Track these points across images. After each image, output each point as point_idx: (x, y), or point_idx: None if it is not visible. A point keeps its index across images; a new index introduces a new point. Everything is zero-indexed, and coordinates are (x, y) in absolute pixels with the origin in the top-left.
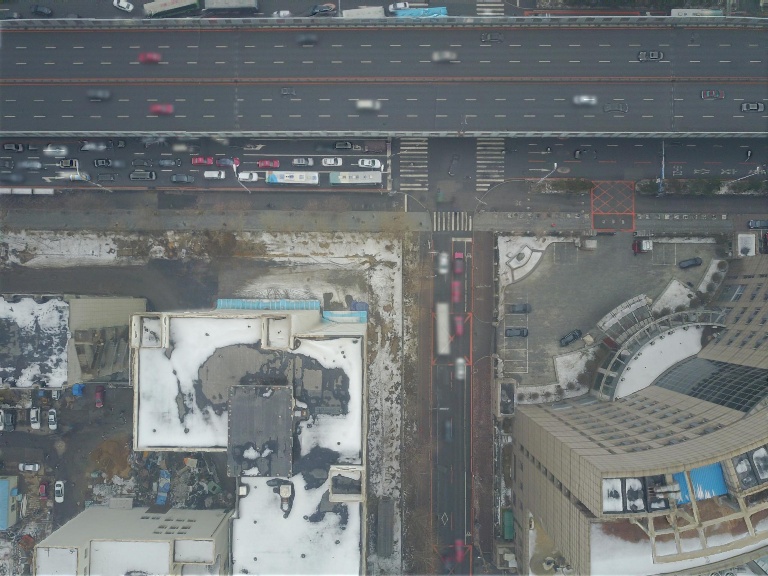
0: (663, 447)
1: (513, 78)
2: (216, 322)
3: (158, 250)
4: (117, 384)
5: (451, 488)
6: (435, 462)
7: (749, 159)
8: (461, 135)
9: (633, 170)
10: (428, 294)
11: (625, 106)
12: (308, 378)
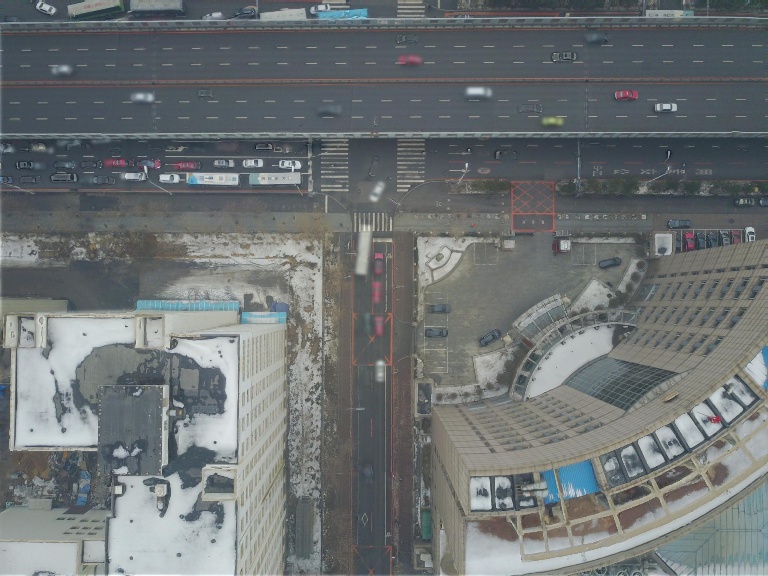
0: (542, 446)
1: (427, 79)
2: (93, 322)
3: (79, 252)
4: None
5: (371, 488)
6: (355, 462)
7: (669, 159)
8: (376, 136)
9: (553, 170)
10: (349, 295)
11: (539, 107)
12: (185, 377)
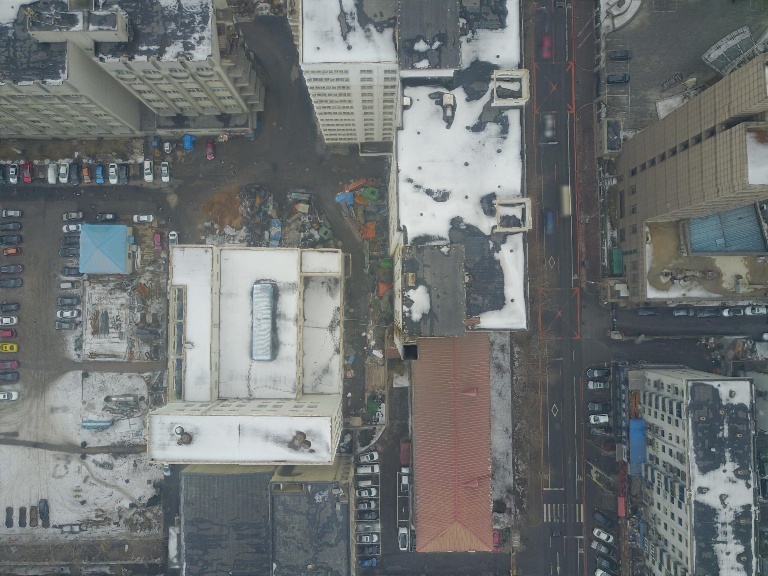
0: None
1: None
2: None
3: (264, 6)
4: (230, 130)
5: (557, 233)
6: (541, 207)
7: None
8: None
9: None
10: (529, 45)
11: None
12: None
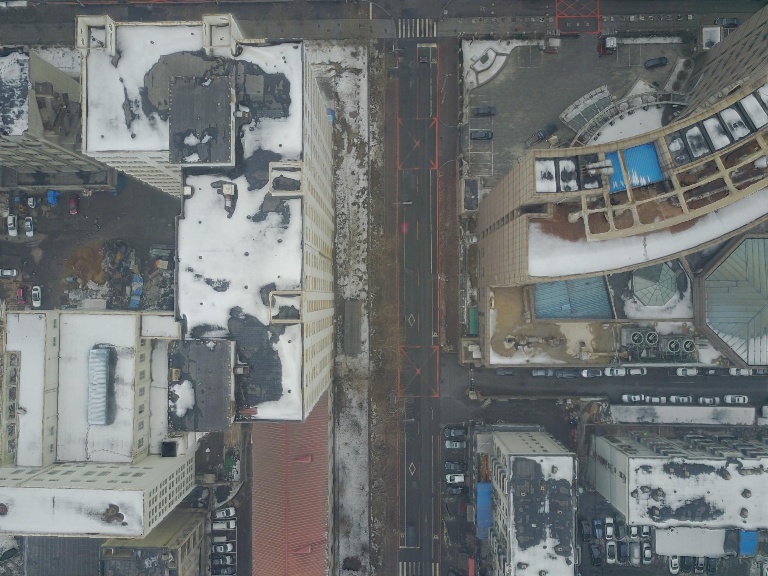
0: None
1: None
2: (160, 30)
3: None
4: (89, 187)
5: (418, 290)
6: (402, 265)
7: None
8: None
9: None
10: (394, 100)
11: None
12: (250, 83)
